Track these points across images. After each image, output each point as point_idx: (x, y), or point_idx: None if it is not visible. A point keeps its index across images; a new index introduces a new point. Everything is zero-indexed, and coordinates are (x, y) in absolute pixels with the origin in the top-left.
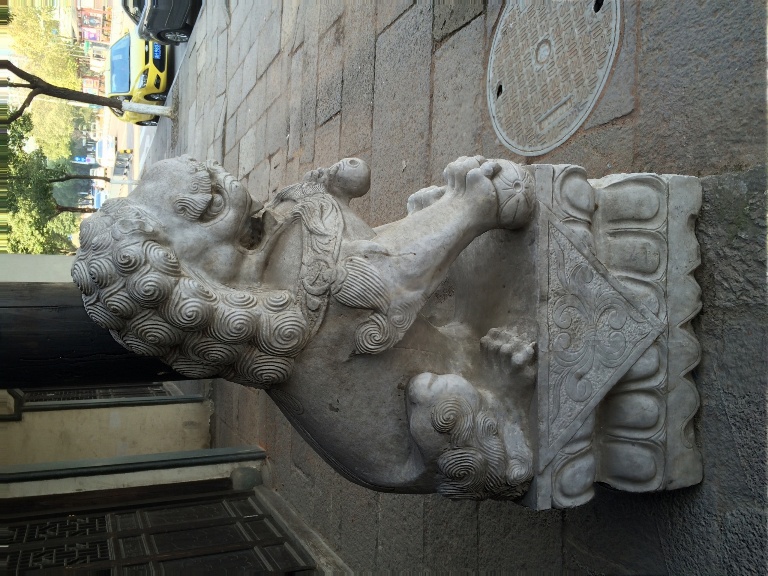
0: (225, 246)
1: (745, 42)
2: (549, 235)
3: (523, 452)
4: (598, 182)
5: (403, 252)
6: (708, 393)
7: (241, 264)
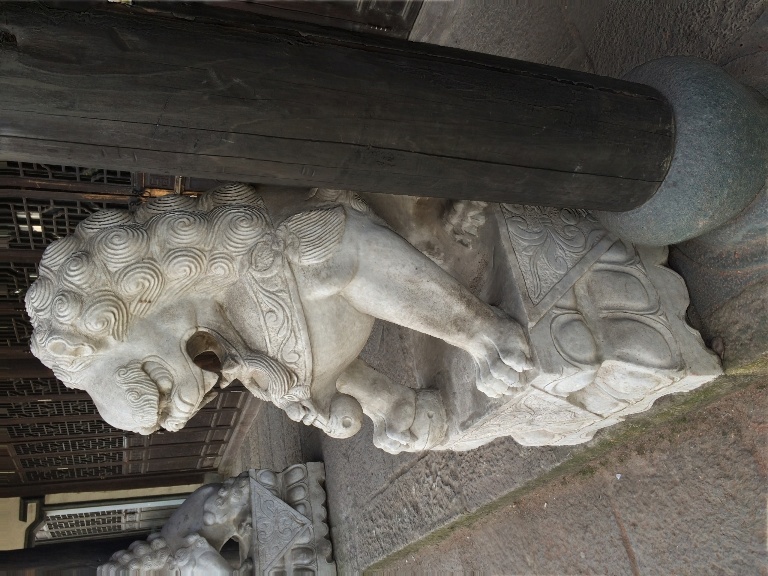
0: None
1: (681, 574)
2: None
3: None
4: None
5: None
6: None
7: None
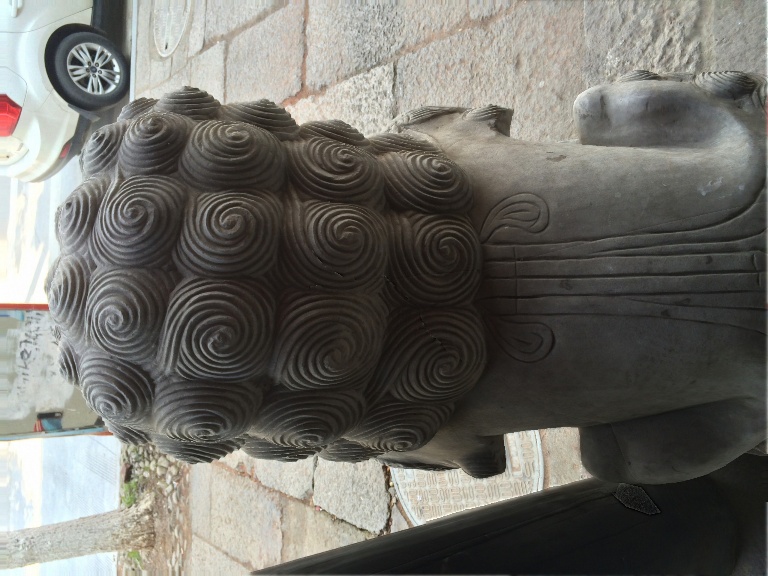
0: None
1: None
2: None
3: None
4: None
5: None
6: None
7: None
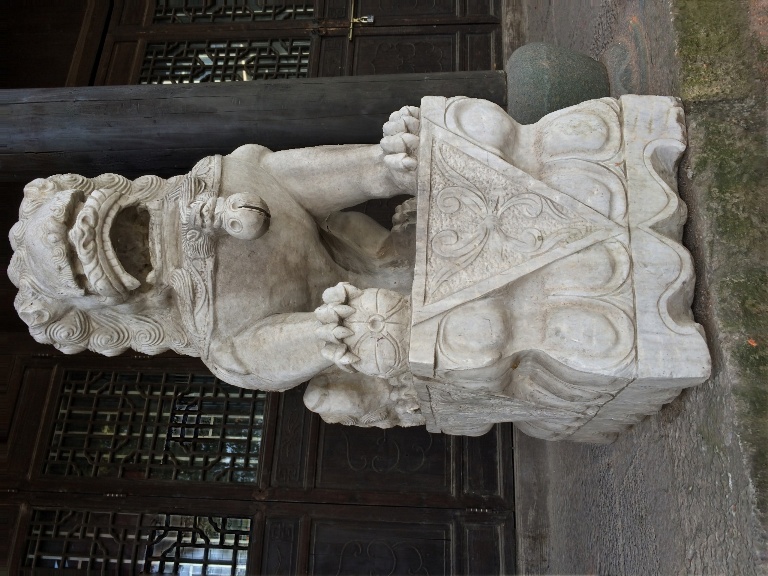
0: (120, 305)
1: None
2: (429, 388)
3: (416, 418)
4: (547, 328)
5: (261, 377)
6: (636, 433)
7: (145, 303)
